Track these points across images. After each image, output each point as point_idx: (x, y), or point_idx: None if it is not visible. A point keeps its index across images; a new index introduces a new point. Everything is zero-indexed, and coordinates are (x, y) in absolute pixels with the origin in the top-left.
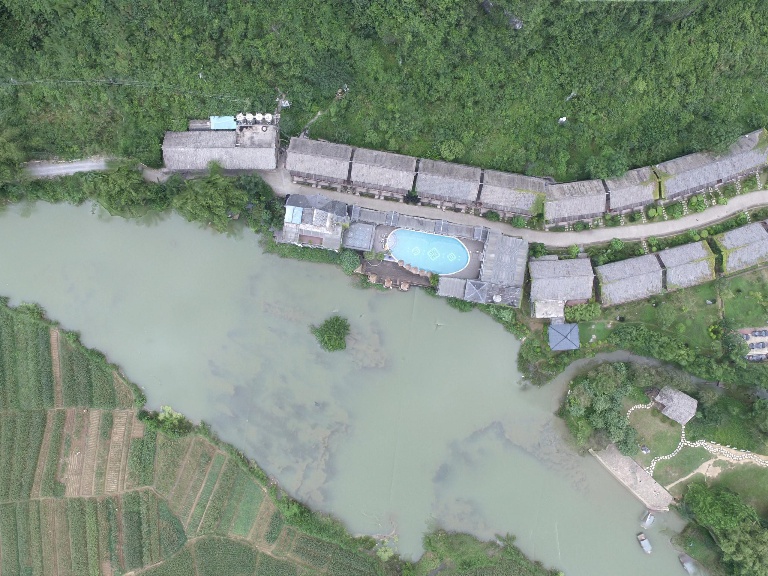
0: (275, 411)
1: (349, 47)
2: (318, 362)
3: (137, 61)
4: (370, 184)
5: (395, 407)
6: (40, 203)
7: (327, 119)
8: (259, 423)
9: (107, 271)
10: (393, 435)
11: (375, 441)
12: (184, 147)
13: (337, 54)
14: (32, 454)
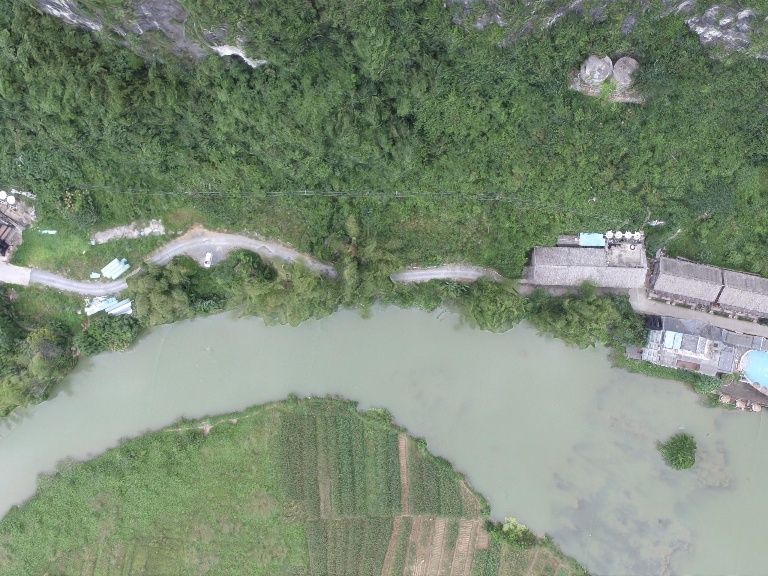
0: (618, 526)
1: (735, 173)
2: (662, 479)
3: (531, 182)
4: (737, 307)
5: (737, 527)
6: (391, 307)
7: (689, 237)
8: (602, 538)
9: (456, 379)
10: (734, 555)
11: (715, 560)
12: (558, 264)
13: (720, 179)
14: (379, 561)
